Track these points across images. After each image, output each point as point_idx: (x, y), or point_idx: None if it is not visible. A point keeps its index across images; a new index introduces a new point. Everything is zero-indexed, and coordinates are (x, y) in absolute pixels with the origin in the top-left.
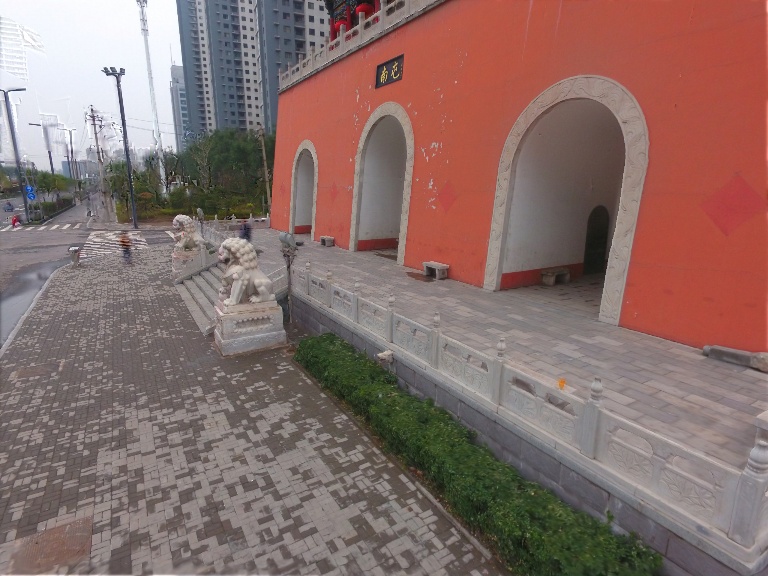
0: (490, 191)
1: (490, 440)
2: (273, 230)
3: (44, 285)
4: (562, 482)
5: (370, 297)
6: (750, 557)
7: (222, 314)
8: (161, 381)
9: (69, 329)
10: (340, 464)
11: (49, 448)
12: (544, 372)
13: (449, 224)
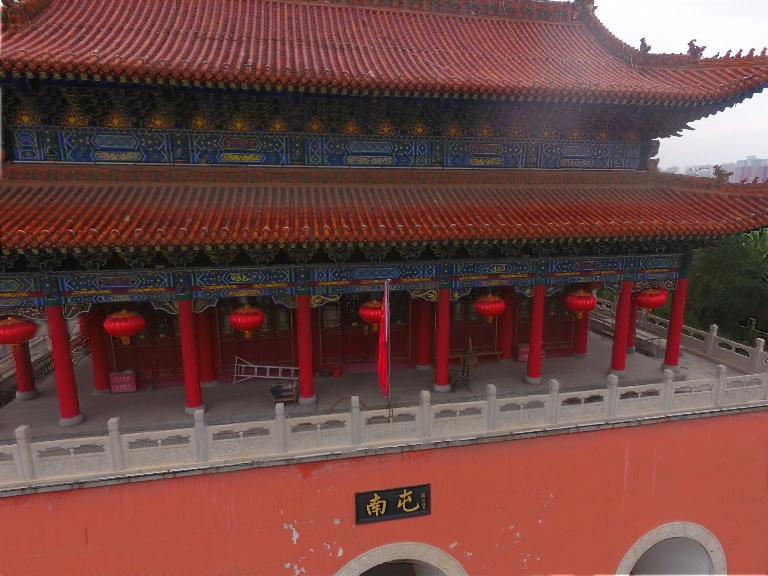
0: None
1: None
2: None
3: None
4: None
5: None
6: None
7: None
8: None
9: None
10: None
11: None
12: None
13: None
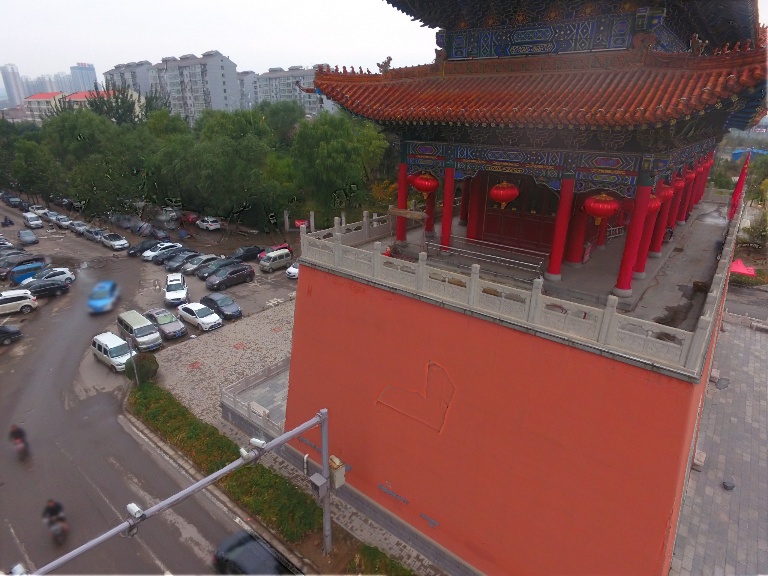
0: None
1: None
2: None
3: None
4: None
5: None
6: None
7: None
8: None
9: None
10: None
11: None
12: None
13: None
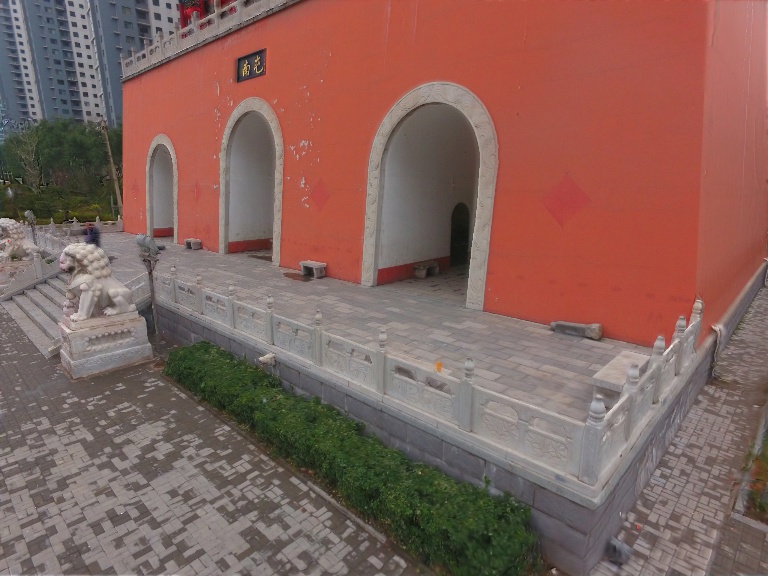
0: (362, 189)
1: (378, 429)
2: (127, 234)
3: None
4: (445, 458)
5: (246, 300)
6: (595, 493)
7: (69, 331)
8: None
9: None
10: (225, 478)
11: None
12: (423, 359)
13: (324, 222)
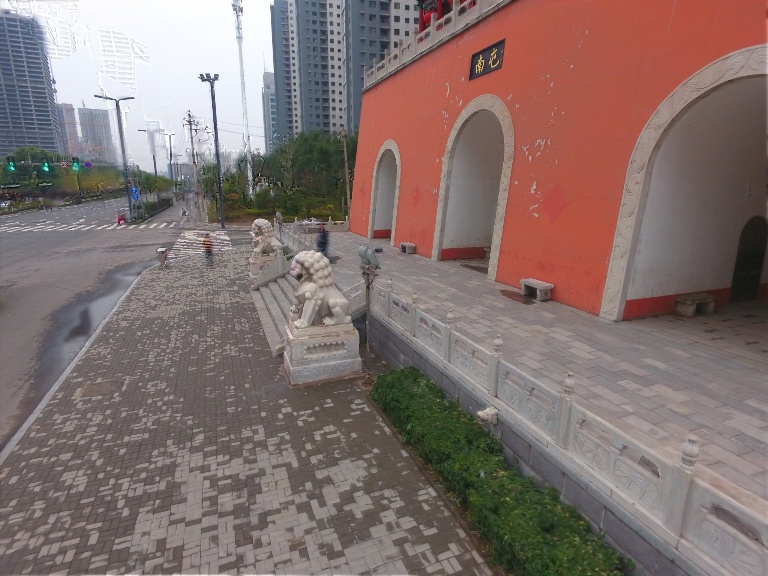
0: (614, 197)
1: None
2: (352, 233)
3: (130, 286)
4: None
5: (460, 322)
6: None
7: (292, 337)
8: (221, 414)
9: (142, 339)
10: (429, 575)
11: (89, 500)
12: (728, 468)
13: (555, 236)
